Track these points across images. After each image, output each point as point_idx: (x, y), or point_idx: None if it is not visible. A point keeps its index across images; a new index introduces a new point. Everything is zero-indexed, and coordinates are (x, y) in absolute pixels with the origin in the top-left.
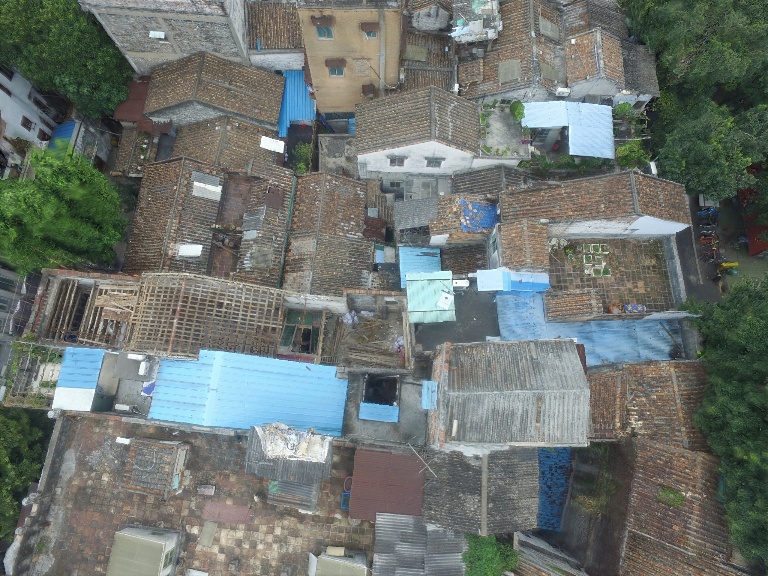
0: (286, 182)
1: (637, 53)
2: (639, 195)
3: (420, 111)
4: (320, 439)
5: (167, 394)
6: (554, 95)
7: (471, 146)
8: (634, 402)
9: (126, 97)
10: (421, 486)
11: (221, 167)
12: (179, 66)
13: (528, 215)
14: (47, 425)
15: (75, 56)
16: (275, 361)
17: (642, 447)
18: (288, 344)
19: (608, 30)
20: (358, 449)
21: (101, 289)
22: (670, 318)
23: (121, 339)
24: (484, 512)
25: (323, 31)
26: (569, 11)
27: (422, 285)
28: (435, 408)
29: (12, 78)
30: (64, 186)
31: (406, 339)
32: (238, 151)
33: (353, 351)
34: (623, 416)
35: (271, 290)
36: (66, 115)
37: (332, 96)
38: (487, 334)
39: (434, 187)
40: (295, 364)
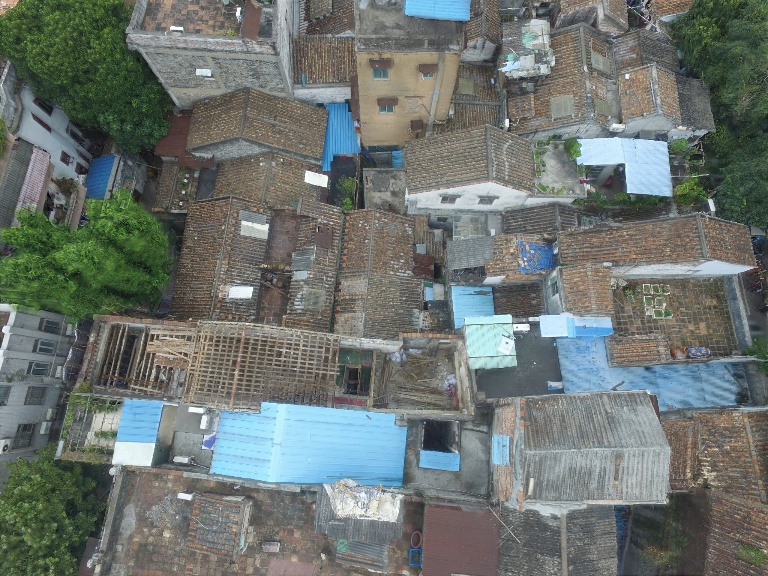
0: (335, 220)
1: (691, 87)
2: (706, 239)
3: (476, 151)
4: (391, 497)
5: (229, 448)
6: (607, 130)
7: (526, 185)
8: (706, 452)
9: (167, 132)
10: (496, 546)
11: (268, 205)
12: (223, 101)
13: (588, 257)
14: (98, 473)
15: (120, 94)
16: (336, 411)
17: (717, 500)
18: (339, 386)
19: (660, 63)
20: (427, 505)
21: (152, 334)
22: (735, 361)
23: (174, 386)
24: (565, 575)
25: (379, 72)
26: (619, 43)
27: (482, 330)
28: (507, 463)
29: (51, 113)
30: (124, 237)
31: (459, 380)
32: (283, 187)
33: (402, 390)
34: (694, 466)
35: (328, 336)
36: (103, 148)
37: (378, 131)
38: (548, 379)
39: (483, 223)
40: (355, 413)
